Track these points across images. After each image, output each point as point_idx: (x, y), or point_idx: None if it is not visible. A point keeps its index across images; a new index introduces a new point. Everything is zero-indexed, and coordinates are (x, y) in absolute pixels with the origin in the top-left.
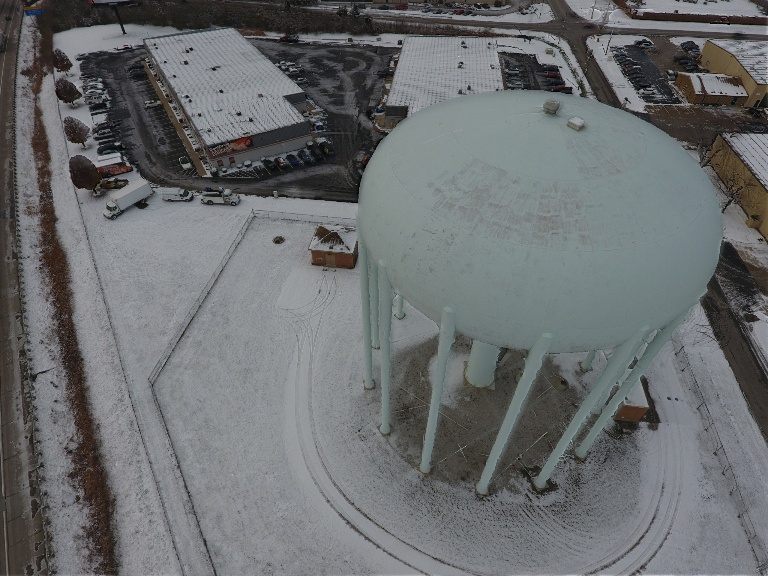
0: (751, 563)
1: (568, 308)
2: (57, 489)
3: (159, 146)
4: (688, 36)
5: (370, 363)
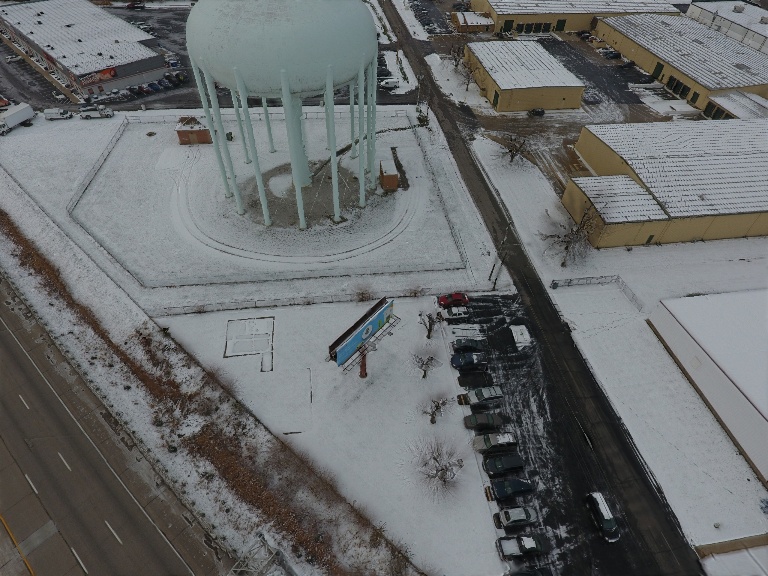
0: (448, 231)
1: (287, 53)
2: (13, 271)
3: (30, 87)
4: None
5: (224, 173)
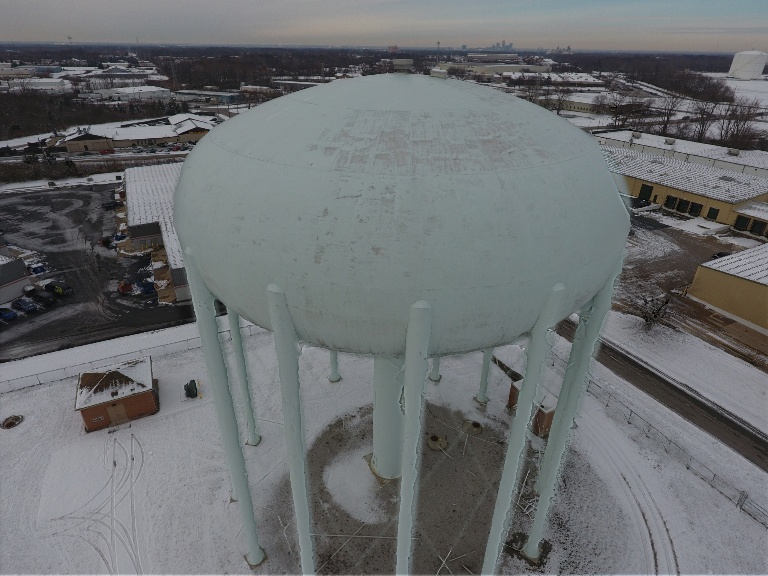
0: (730, 506)
1: (571, 237)
2: None
3: None
4: None
5: (252, 518)
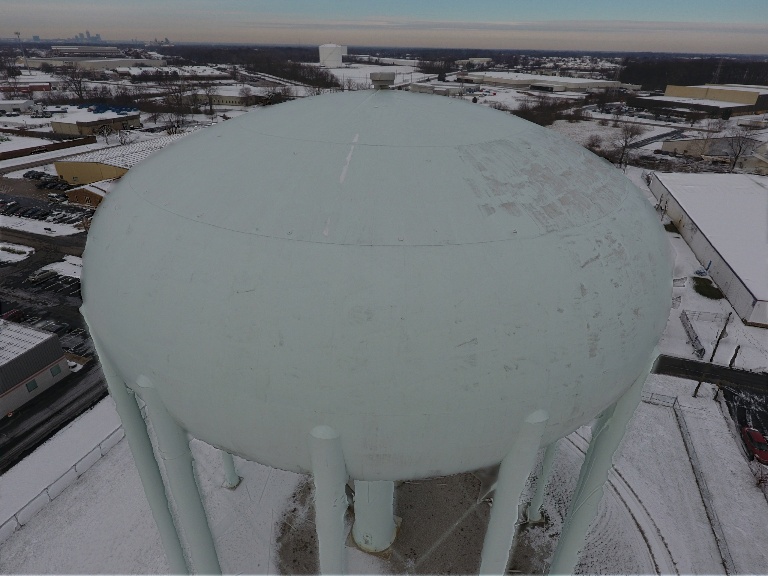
0: None
1: None
2: None
3: None
4: (18, 170)
5: None
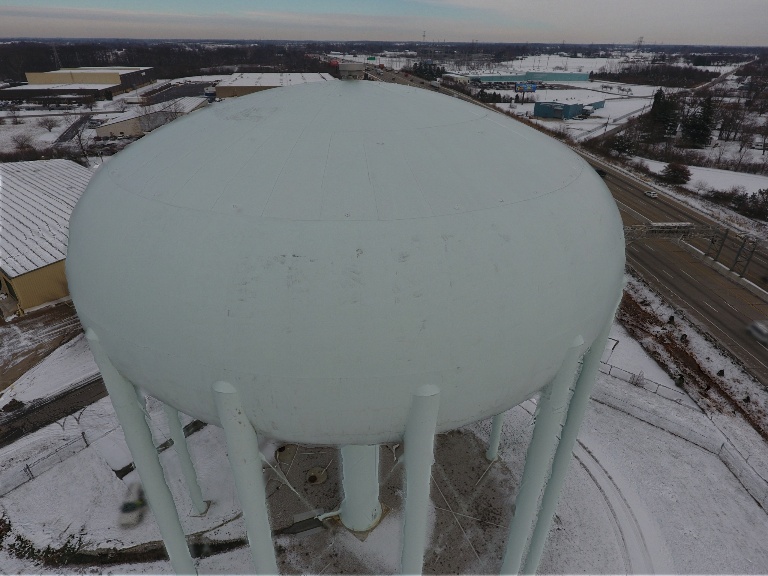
0: None
1: None
2: None
3: None
4: None
5: None
